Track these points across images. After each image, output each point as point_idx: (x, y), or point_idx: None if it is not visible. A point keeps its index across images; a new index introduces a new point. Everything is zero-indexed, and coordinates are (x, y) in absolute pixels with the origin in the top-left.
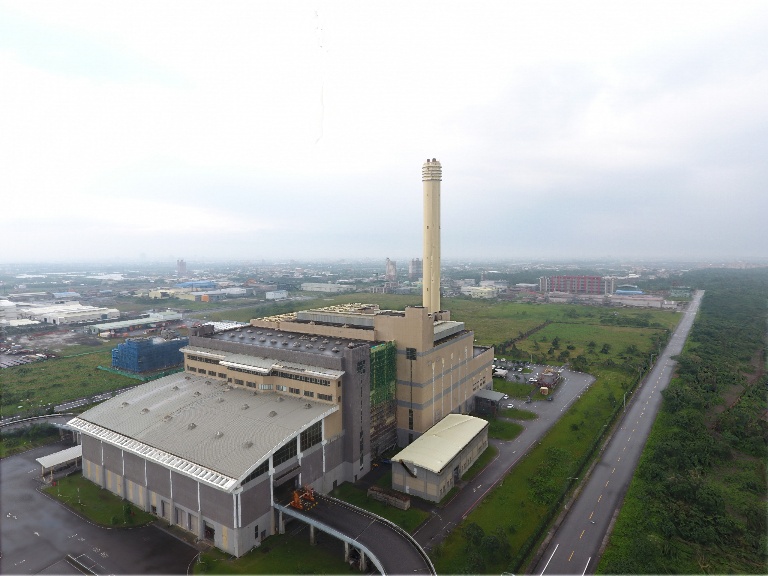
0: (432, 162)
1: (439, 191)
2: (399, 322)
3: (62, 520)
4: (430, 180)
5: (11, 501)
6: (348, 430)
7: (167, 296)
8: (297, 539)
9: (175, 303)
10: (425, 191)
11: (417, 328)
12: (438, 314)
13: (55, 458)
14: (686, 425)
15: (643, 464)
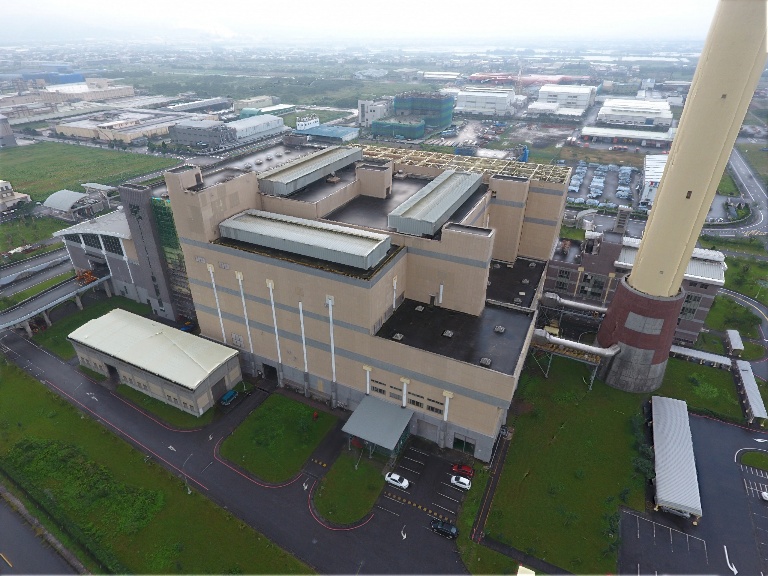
0: None
1: None
2: None
3: None
4: None
5: None
6: None
7: None
8: (81, 297)
9: None
10: None
11: None
12: None
13: None
14: None
15: None
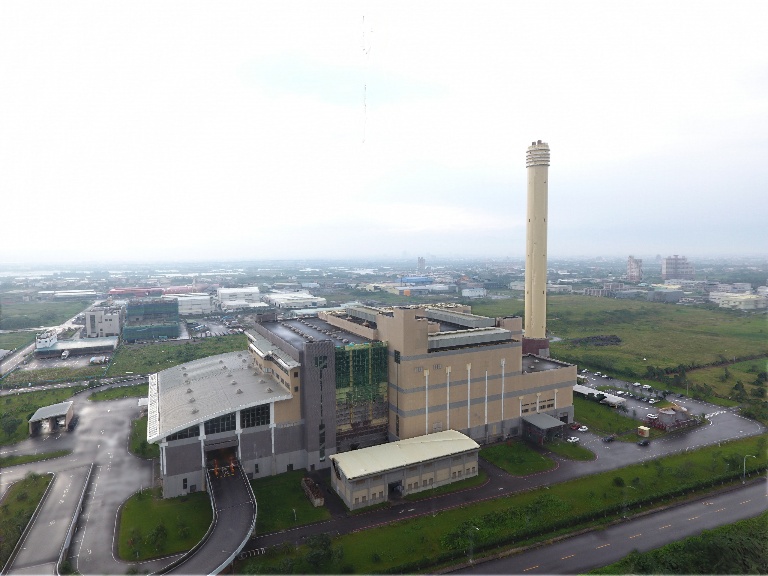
0: (535, 145)
1: (545, 178)
2: (390, 323)
3: (118, 442)
4: (532, 166)
5: (113, 423)
6: (305, 420)
7: (379, 289)
8: None
9: (380, 296)
10: (528, 179)
11: (400, 330)
12: (500, 320)
13: None
14: None
15: (658, 552)
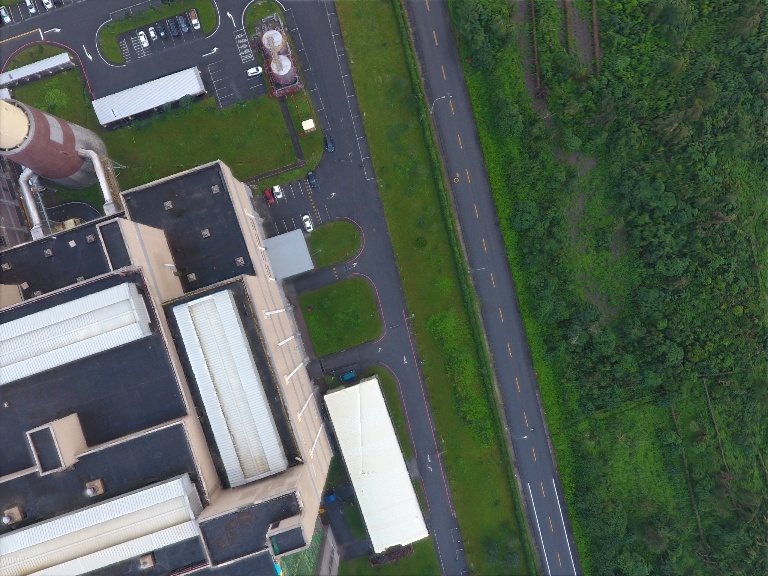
0: None
1: None
2: None
3: None
4: None
5: None
6: None
7: None
8: None
9: None
10: None
11: None
12: None
13: None
14: (522, 134)
15: (519, 281)
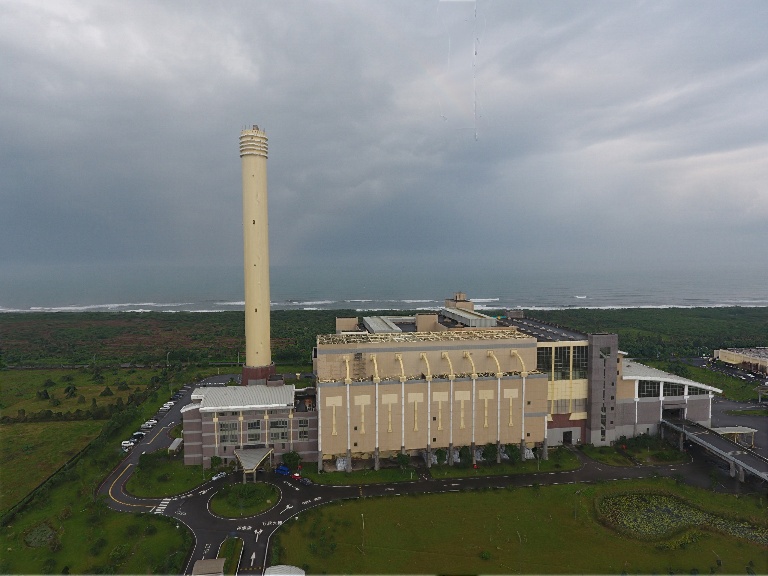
0: None
1: None
2: None
3: None
4: None
5: (757, 436)
6: None
7: None
8: None
9: None
10: None
11: None
12: None
13: (739, 428)
14: None
15: None
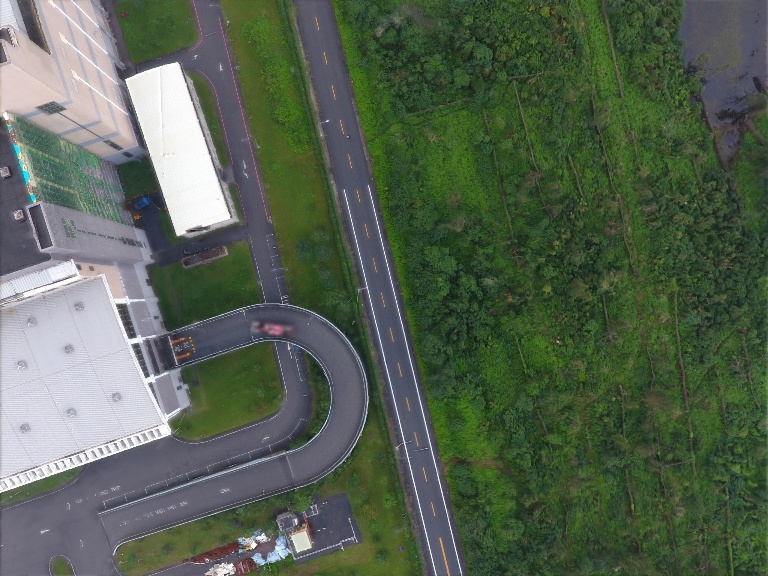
0: None
1: None
2: None
3: (34, 512)
4: None
5: None
6: None
7: None
8: None
9: None
10: None
11: (29, 85)
12: None
13: None
14: None
15: None
